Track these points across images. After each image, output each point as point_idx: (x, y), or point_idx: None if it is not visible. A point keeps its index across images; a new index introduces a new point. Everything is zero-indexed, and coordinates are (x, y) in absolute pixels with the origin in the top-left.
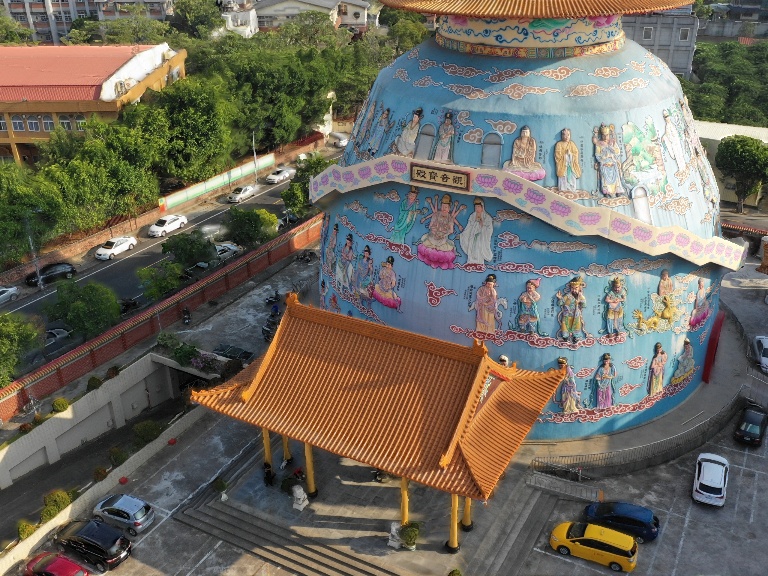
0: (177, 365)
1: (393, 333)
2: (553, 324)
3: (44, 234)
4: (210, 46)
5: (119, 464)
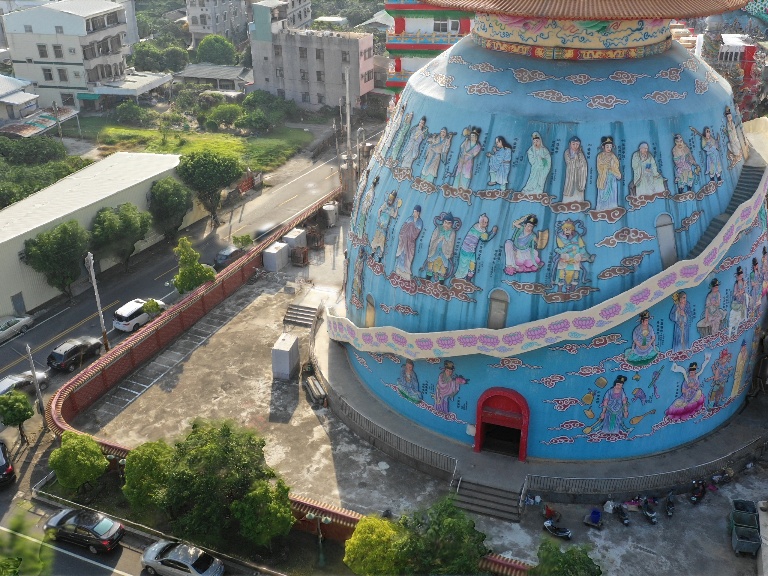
0: None
1: None
2: None
3: None
4: None
5: None
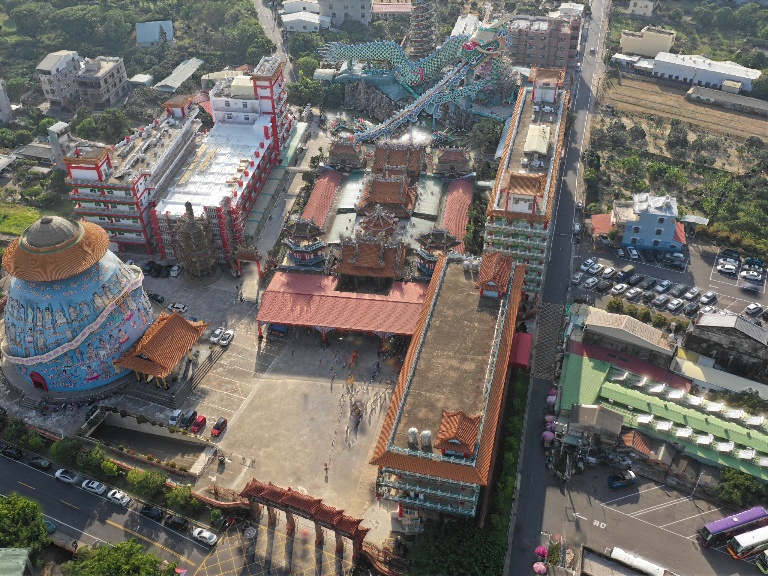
0: None
1: None
2: None
3: None
4: None
5: (156, 423)
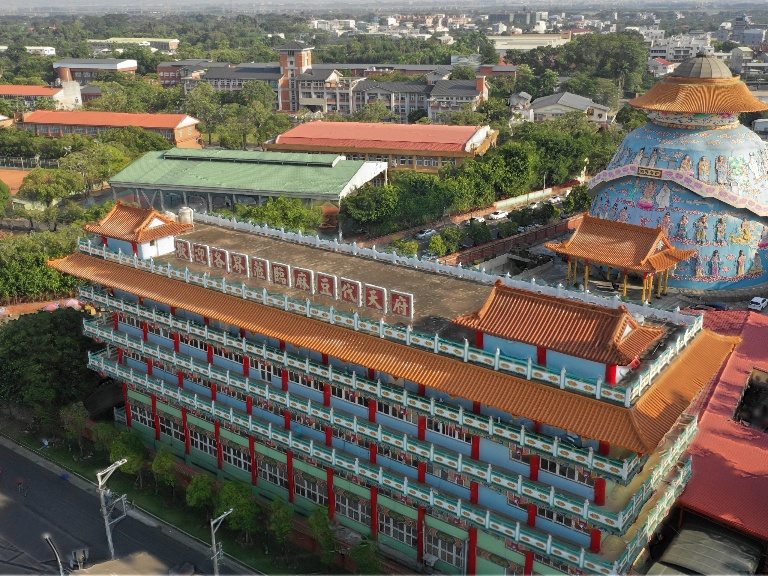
0: (520, 258)
1: (626, 225)
2: (693, 234)
3: (445, 209)
4: (507, 130)
5: None
